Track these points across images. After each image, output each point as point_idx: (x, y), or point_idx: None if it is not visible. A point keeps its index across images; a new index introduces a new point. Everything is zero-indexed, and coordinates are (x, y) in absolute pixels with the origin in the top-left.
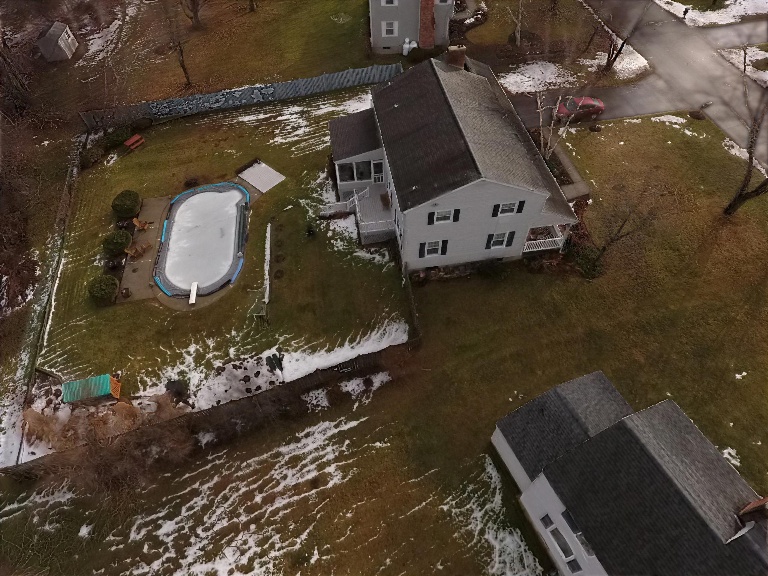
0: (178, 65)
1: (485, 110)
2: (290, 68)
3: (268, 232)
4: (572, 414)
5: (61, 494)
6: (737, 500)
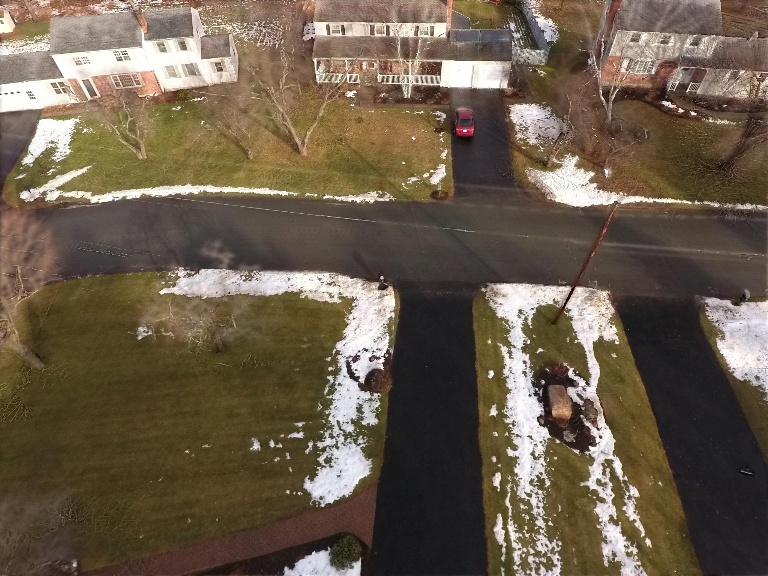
0: (590, 6)
1: (395, 8)
2: (578, 34)
3: None
4: None
5: None
6: (151, 29)
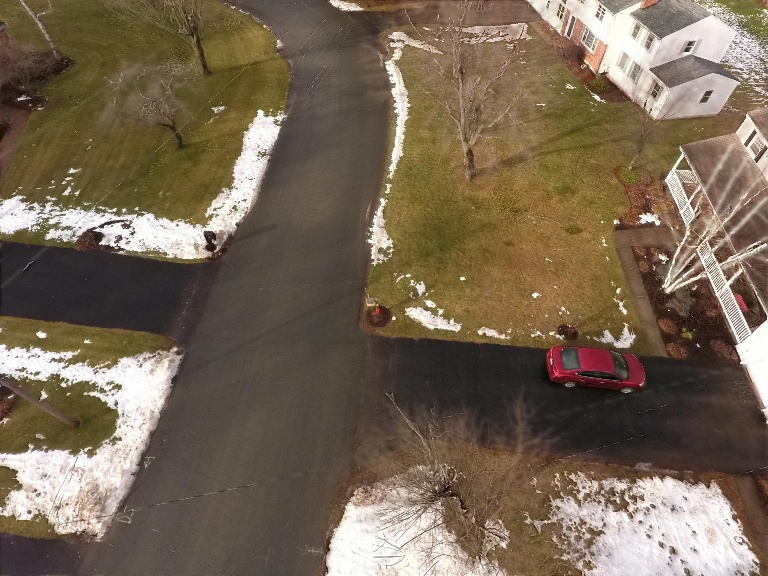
0: None
1: None
2: None
3: None
4: (703, 64)
5: None
6: (651, 8)
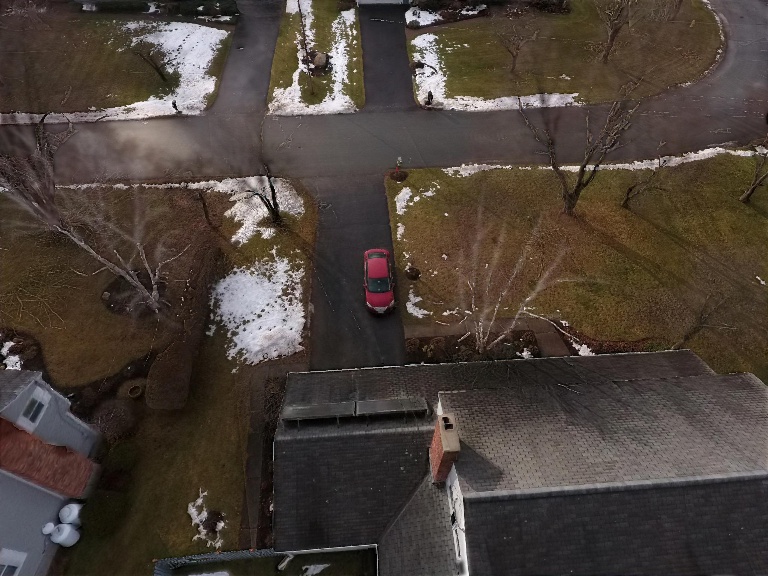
0: None
1: (584, 418)
2: None
3: None
4: None
5: None
6: None
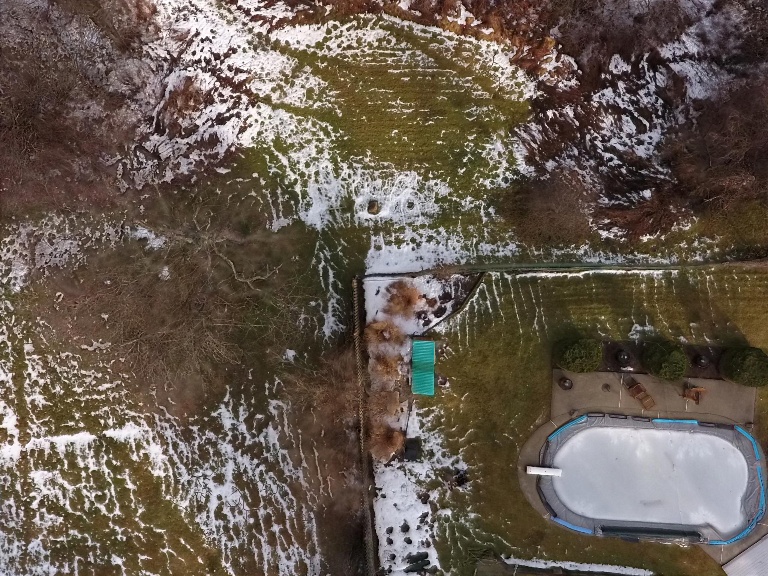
0: None
1: None
2: None
3: (634, 571)
4: None
5: (331, 324)
6: None
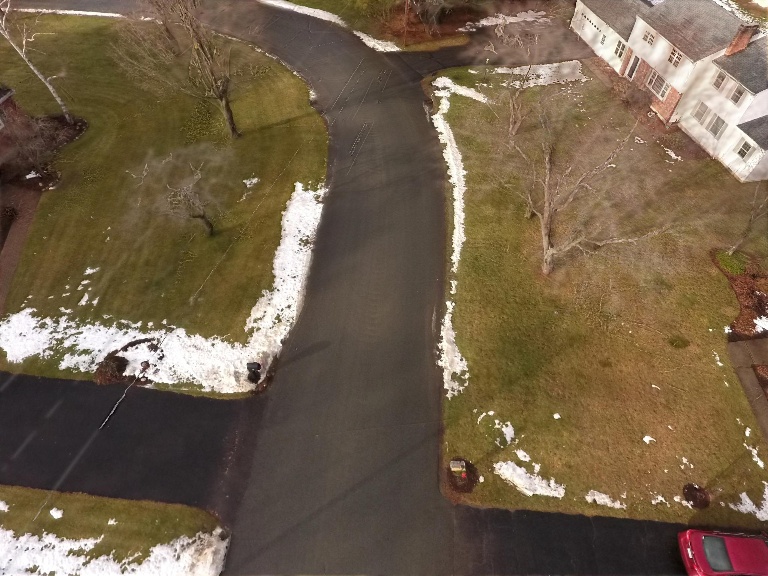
0: None
1: None
2: None
3: None
4: None
5: None
6: (738, 56)
